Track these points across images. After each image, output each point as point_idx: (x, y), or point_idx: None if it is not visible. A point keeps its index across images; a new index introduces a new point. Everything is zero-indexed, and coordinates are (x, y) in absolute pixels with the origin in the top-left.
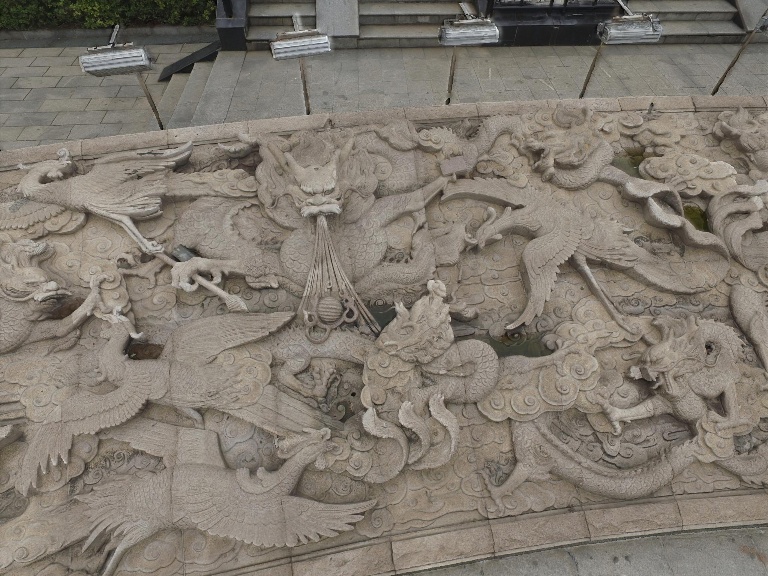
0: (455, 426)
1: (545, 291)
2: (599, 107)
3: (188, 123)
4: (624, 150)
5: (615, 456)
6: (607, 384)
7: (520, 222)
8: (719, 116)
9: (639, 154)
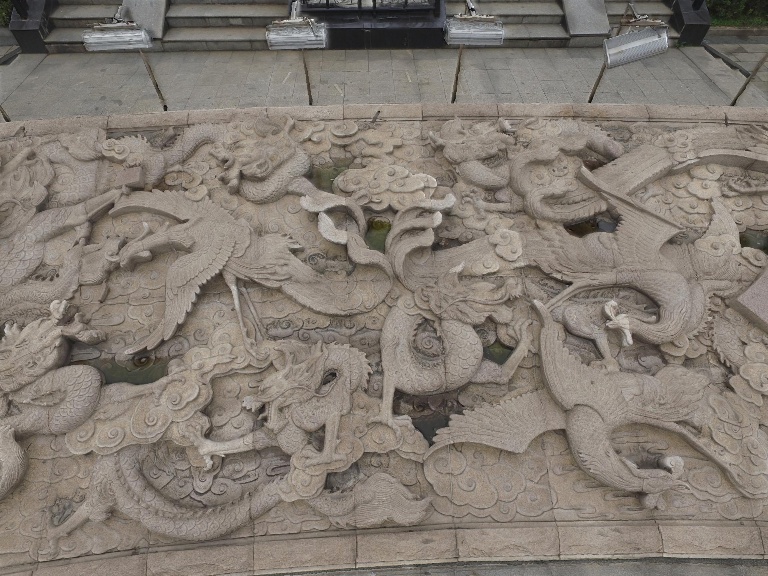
0: (13, 461)
1: (179, 312)
2: (319, 115)
3: None
4: (331, 161)
5: (204, 493)
6: (222, 413)
7: (175, 238)
8: (442, 125)
9: (346, 165)
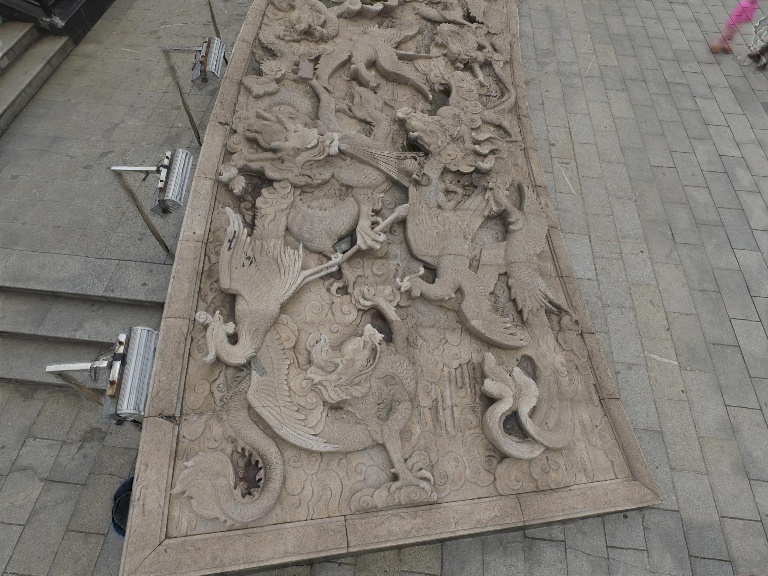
0: None
1: (412, 73)
2: None
3: (52, 310)
4: None
5: None
6: None
7: (364, 60)
8: None
9: None
